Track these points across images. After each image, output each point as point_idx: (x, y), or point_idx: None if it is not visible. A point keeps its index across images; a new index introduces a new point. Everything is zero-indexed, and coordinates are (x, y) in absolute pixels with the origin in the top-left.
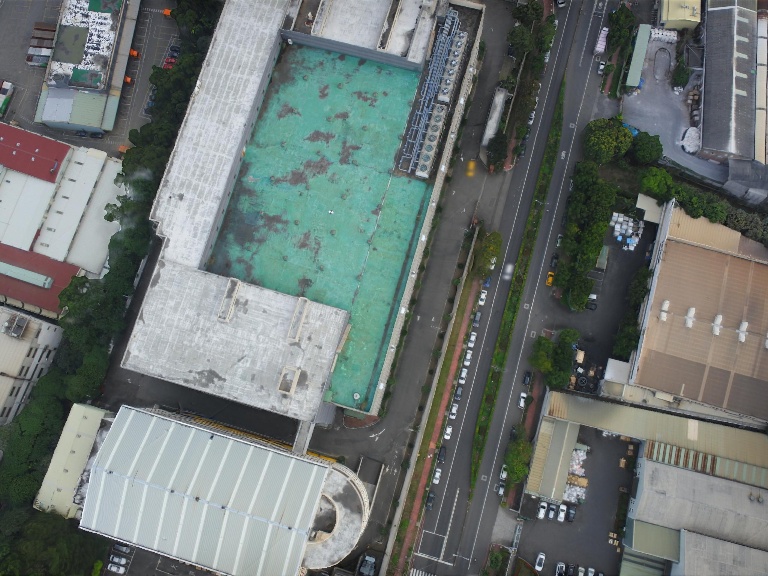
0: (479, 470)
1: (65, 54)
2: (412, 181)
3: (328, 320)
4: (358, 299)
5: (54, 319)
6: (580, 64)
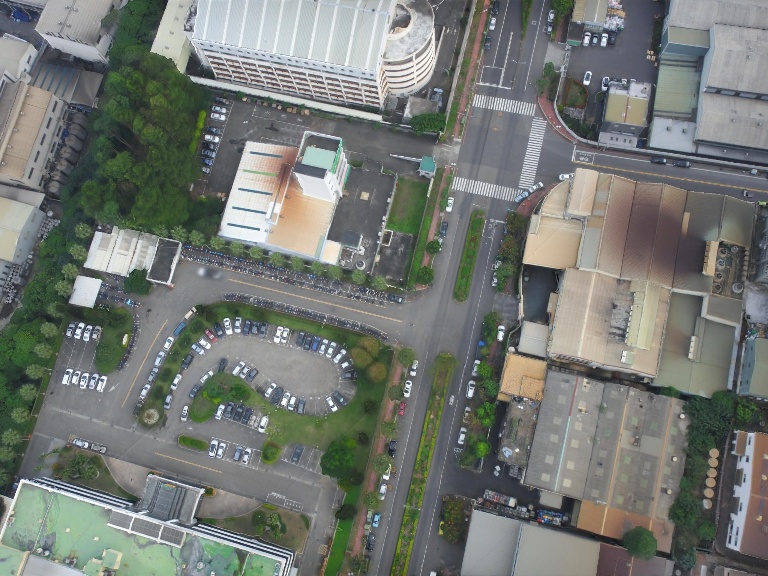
0: (529, 17)
1: None
2: None
3: None
4: None
5: None
6: None
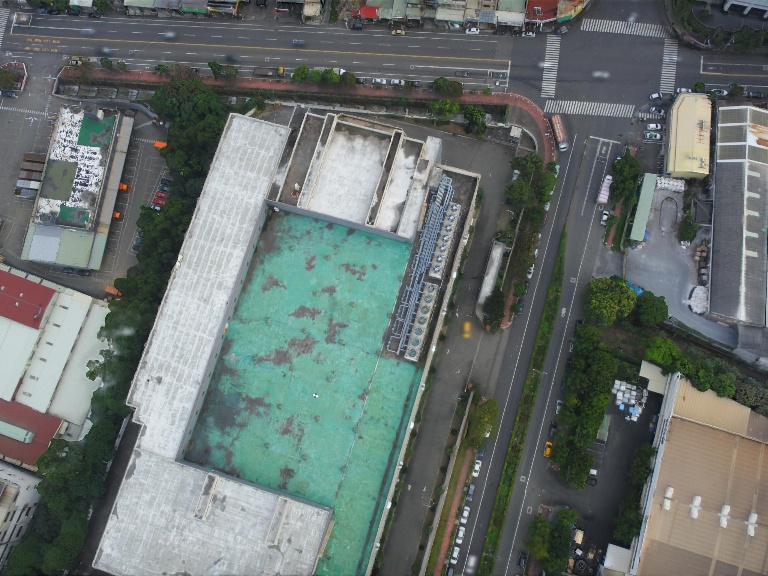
0: None
1: (53, 190)
2: (401, 363)
3: (309, 521)
4: (342, 492)
5: (35, 472)
6: (582, 213)
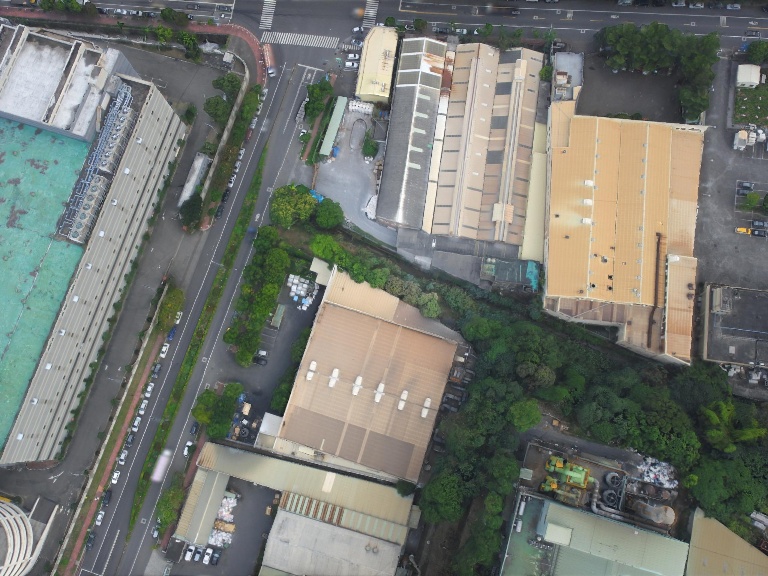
0: (139, 513)
1: None
2: (70, 245)
3: None
4: (8, 355)
5: None
6: (284, 131)
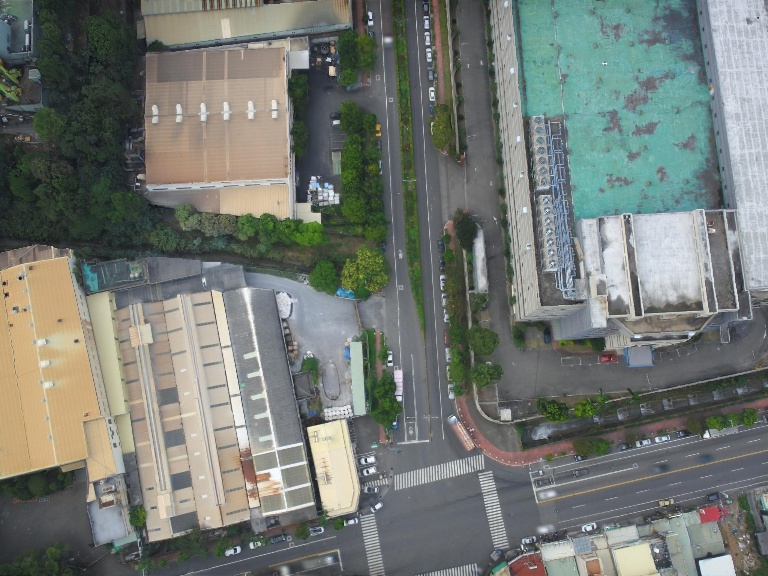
0: None
1: None
2: None
3: None
4: None
5: None
6: (412, 357)
